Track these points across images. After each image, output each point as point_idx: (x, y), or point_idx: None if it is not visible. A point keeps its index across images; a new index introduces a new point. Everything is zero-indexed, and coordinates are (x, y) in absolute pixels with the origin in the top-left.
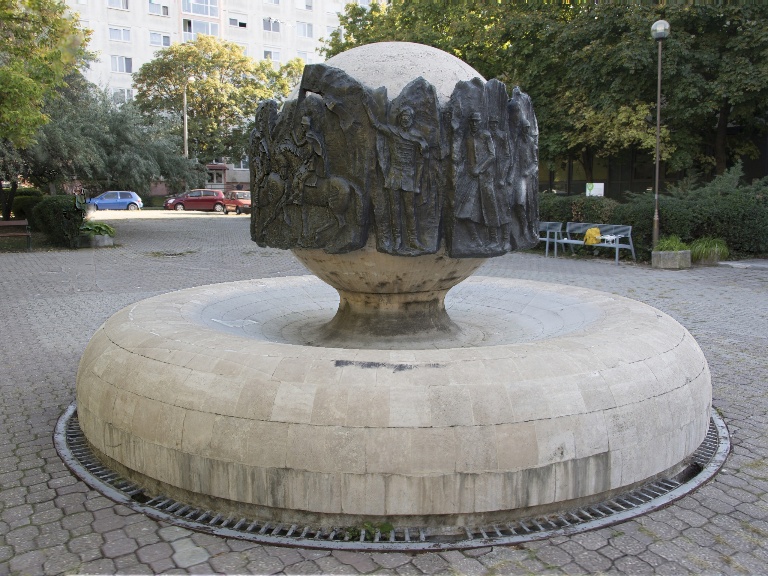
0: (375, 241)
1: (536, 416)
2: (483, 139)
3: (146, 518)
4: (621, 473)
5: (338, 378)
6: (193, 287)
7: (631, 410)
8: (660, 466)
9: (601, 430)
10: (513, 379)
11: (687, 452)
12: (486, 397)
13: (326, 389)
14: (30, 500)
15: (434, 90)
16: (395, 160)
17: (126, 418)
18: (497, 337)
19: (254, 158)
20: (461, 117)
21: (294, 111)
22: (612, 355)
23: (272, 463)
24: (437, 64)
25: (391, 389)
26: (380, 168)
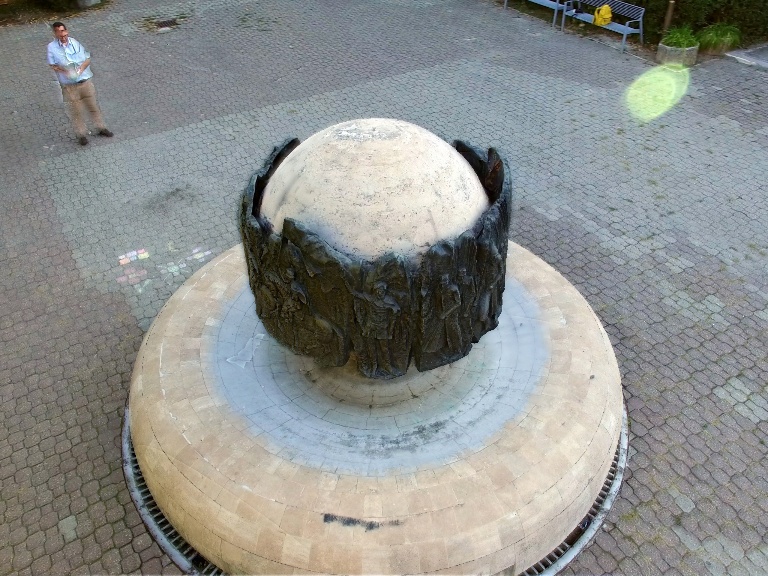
0: (356, 359)
1: (464, 561)
2: (450, 293)
3: None
4: (523, 568)
5: (326, 536)
6: (205, 274)
7: (536, 535)
8: (554, 548)
9: (511, 556)
10: (451, 533)
11: (579, 522)
12: (430, 553)
13: (318, 545)
14: (125, 569)
15: (406, 266)
16: (371, 318)
17: (179, 520)
18: (462, 361)
19: (246, 242)
20: (430, 282)
21: (279, 254)
22: (531, 487)
23: None
24: (413, 203)
25: (363, 549)
26: (358, 322)
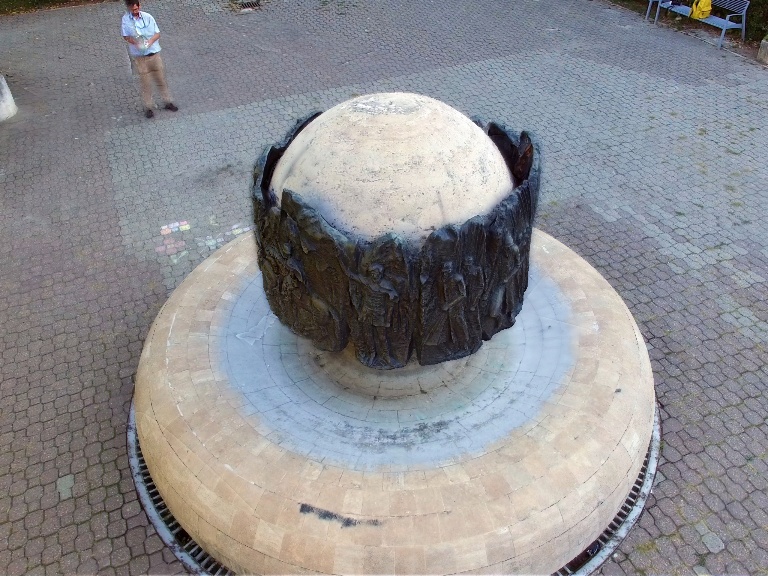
0: None
1: (444, 573)
2: (454, 283)
3: (182, 569)
4: None
5: (300, 527)
6: (230, 248)
7: (529, 555)
8: (552, 572)
9: (498, 575)
10: (432, 541)
11: (585, 548)
12: (407, 559)
13: (291, 536)
14: (110, 533)
15: (403, 249)
16: (366, 303)
17: (163, 491)
18: (480, 360)
19: None
20: (431, 269)
21: (278, 227)
22: (528, 503)
23: (256, 572)
24: (420, 182)
25: (337, 545)
26: (354, 305)
